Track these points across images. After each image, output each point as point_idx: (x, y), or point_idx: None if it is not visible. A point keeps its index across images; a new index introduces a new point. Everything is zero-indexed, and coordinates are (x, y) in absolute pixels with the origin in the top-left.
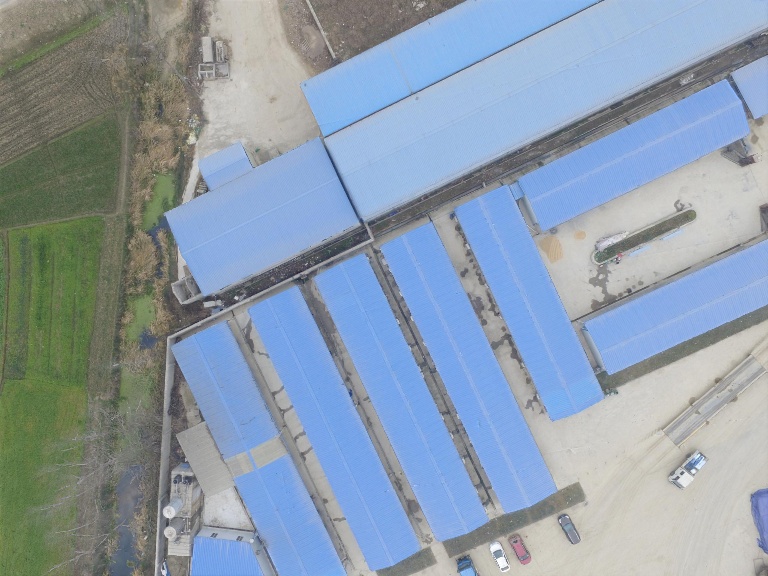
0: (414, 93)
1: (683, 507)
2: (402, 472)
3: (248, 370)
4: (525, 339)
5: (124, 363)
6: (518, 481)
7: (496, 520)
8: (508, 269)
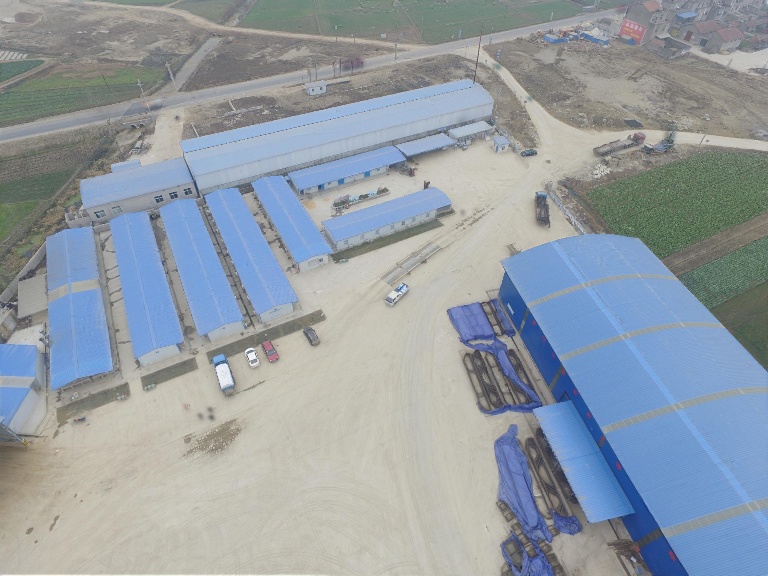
0: (235, 141)
1: (399, 321)
2: (187, 309)
3: (94, 247)
4: (284, 227)
5: (4, 263)
6: (268, 292)
7: (254, 336)
8: (277, 200)
